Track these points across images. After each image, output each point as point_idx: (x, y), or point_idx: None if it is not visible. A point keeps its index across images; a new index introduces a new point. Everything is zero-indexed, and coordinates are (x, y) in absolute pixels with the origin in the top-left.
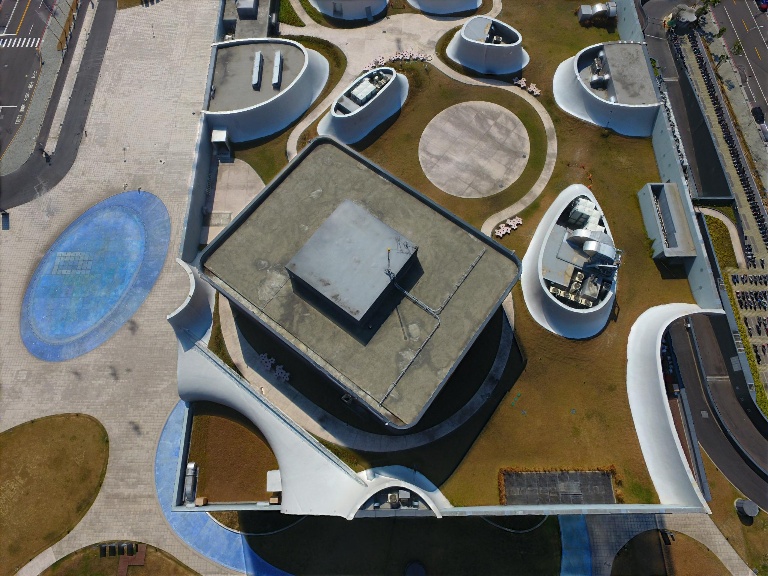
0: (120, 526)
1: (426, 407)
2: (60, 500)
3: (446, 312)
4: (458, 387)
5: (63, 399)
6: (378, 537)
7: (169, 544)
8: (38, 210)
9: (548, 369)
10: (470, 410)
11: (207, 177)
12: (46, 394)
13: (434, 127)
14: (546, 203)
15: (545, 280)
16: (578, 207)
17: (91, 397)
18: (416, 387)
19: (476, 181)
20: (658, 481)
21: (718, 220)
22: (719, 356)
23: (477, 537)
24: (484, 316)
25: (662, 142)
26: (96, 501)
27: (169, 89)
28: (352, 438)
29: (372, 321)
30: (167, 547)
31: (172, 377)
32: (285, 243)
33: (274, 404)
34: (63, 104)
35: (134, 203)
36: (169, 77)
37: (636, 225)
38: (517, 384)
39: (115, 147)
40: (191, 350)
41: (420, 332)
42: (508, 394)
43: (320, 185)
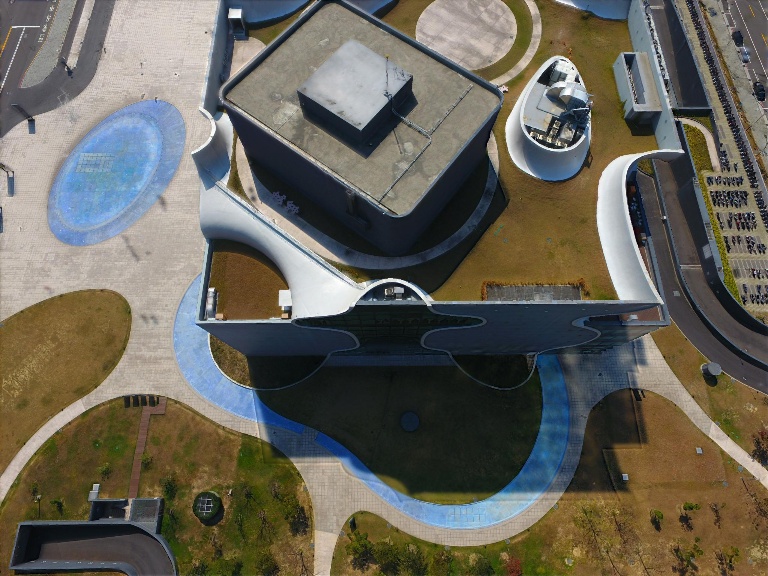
0: (143, 382)
1: (418, 201)
2: (88, 361)
3: (437, 133)
4: (448, 220)
5: (89, 277)
6: (376, 393)
7: (187, 397)
8: (62, 117)
9: (528, 207)
10: (458, 238)
11: (224, 51)
12: (73, 273)
13: (430, 12)
14: (530, 74)
15: (526, 126)
16: (557, 67)
17: (114, 275)
18: (410, 189)
19: (467, 57)
20: (621, 290)
21: (696, 128)
22: (693, 248)
23: (466, 393)
24: (470, 136)
25: (636, 20)
26: (120, 362)
27: (183, 11)
28: (354, 259)
29: (372, 140)
30: (185, 400)
31: (188, 259)
32: (296, 80)
33: (285, 231)
34: (83, 24)
35: (151, 111)
36: (182, 0)
37: (610, 92)
38: (500, 218)
39: (133, 62)
40: (212, 189)
41: (414, 148)
42: (492, 226)
43: (327, 35)
